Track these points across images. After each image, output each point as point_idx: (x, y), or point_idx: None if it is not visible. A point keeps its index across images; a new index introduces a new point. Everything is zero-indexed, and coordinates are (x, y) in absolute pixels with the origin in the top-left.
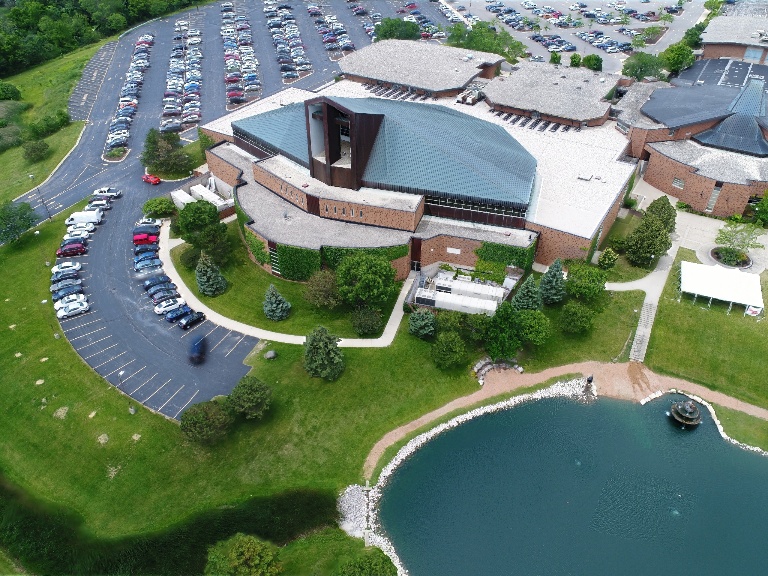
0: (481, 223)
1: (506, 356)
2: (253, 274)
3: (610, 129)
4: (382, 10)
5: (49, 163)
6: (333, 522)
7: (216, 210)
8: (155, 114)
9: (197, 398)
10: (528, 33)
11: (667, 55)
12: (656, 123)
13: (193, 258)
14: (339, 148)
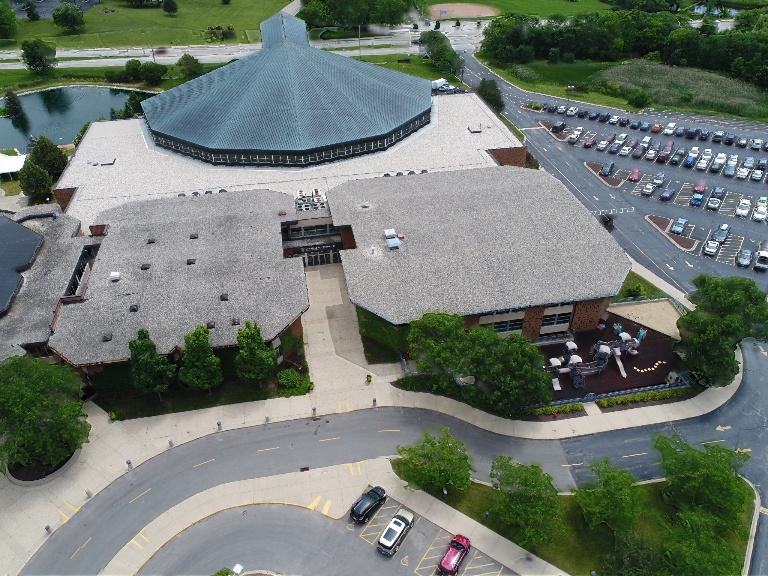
0: None
1: None
2: None
3: None
4: None
5: None
6: None
7: None
8: None
9: None
10: None
11: None
12: None
13: None
14: None
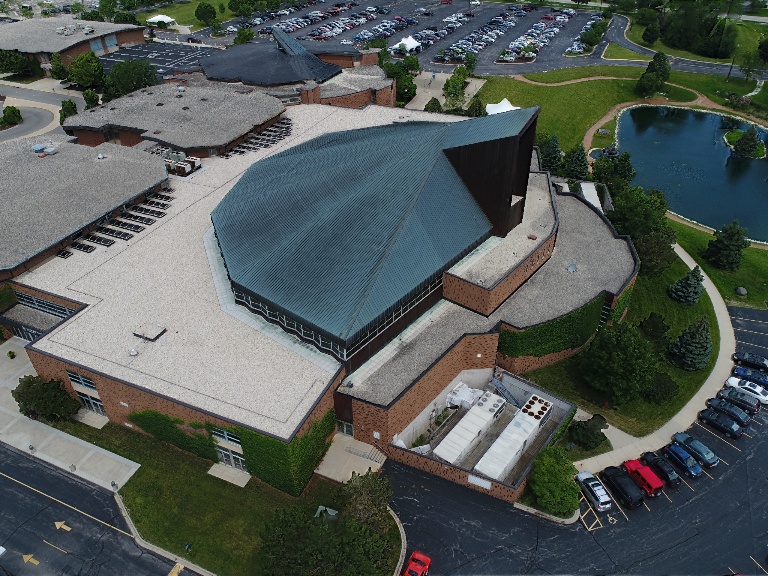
0: None
1: None
2: None
3: None
4: None
5: None
6: None
7: None
8: None
9: None
10: None
11: (90, 67)
12: (298, 84)
13: None
14: None
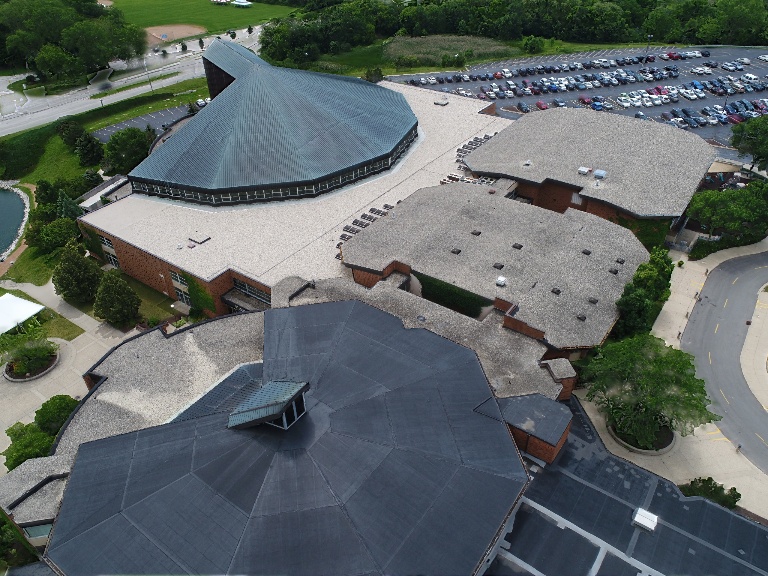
0: None
1: None
2: None
3: None
4: None
5: (391, 73)
6: (1, 175)
7: None
8: None
9: (102, 135)
10: None
11: None
12: None
13: None
14: None
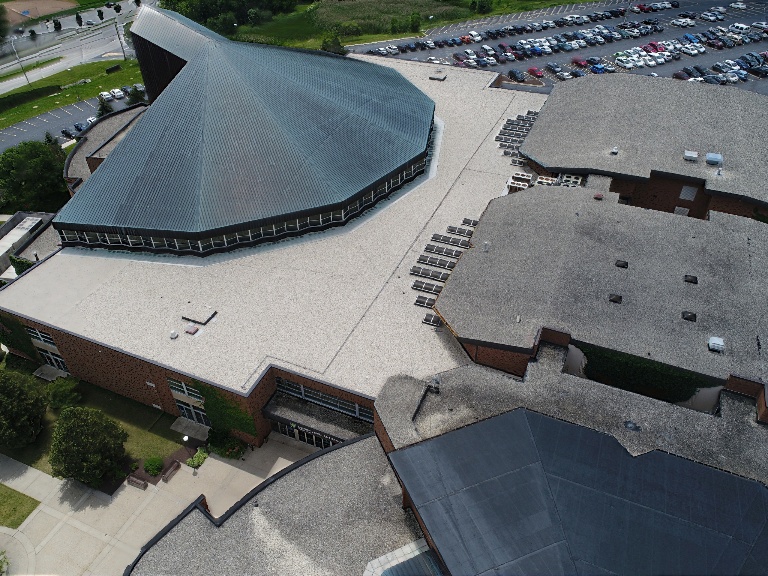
0: None
1: None
2: None
3: None
4: None
5: None
6: None
7: None
8: None
9: None
10: None
11: None
12: None
13: None
14: None
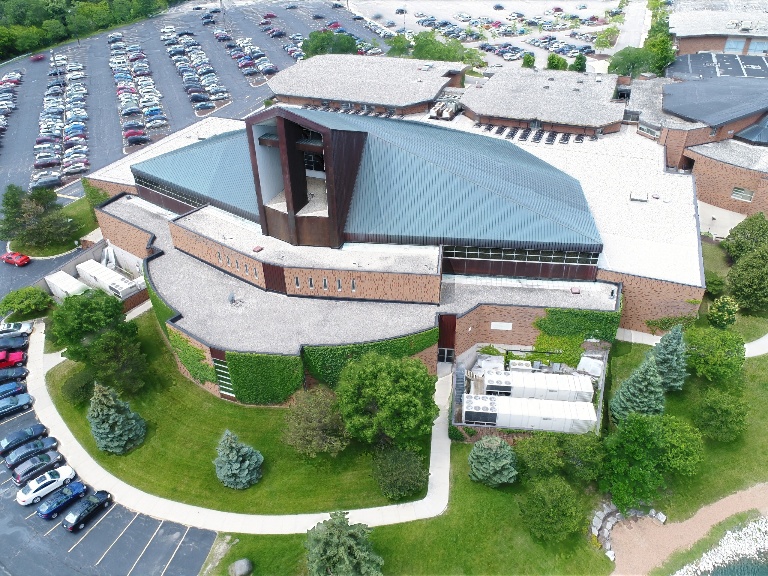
0: (530, 278)
1: (640, 501)
2: (189, 401)
3: (631, 135)
4: (301, 31)
5: None
6: None
7: (117, 303)
8: (23, 167)
9: None
10: (473, 44)
11: None
12: (690, 122)
13: (84, 386)
14: (305, 187)
